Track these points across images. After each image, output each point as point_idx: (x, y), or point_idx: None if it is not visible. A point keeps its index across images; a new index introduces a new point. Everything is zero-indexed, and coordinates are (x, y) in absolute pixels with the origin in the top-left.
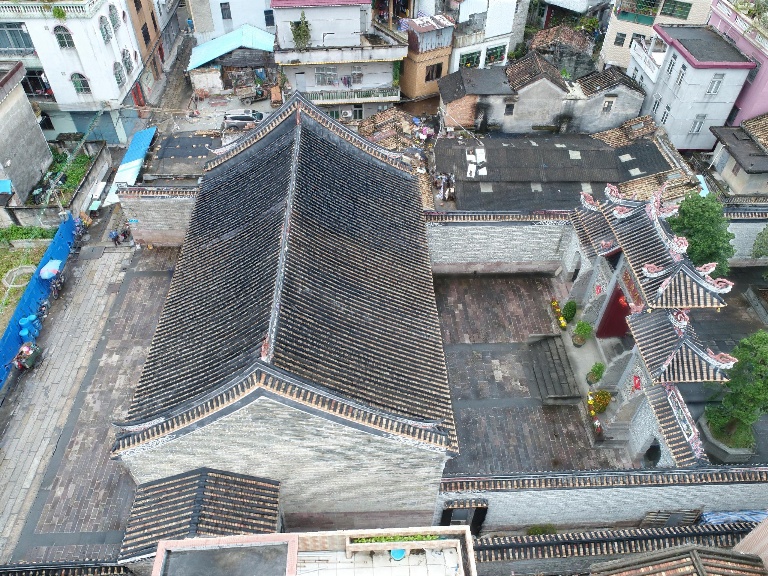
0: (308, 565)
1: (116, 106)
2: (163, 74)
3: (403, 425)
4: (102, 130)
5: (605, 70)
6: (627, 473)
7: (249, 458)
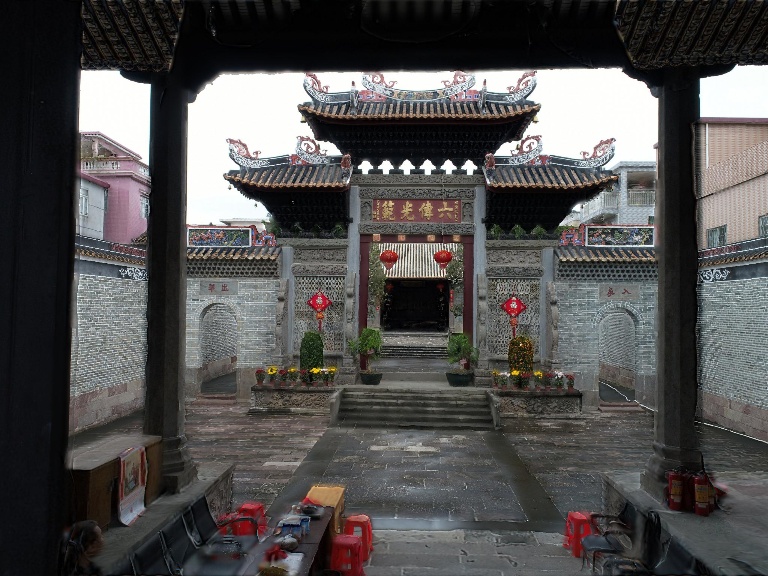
0: None
1: None
2: None
3: None
4: None
5: None
6: None
7: None
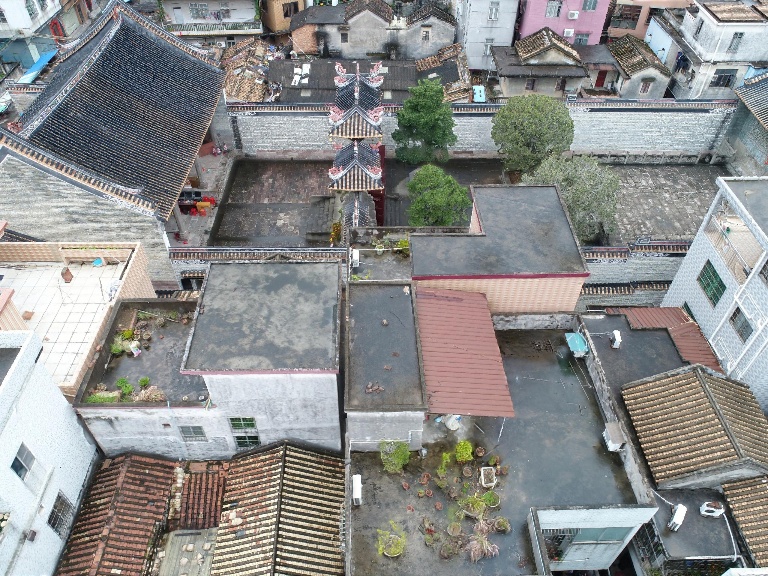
0: (39, 267)
1: (28, 34)
2: (89, 20)
3: (117, 190)
4: (21, 56)
5: (425, 6)
6: (303, 249)
7: (23, 217)
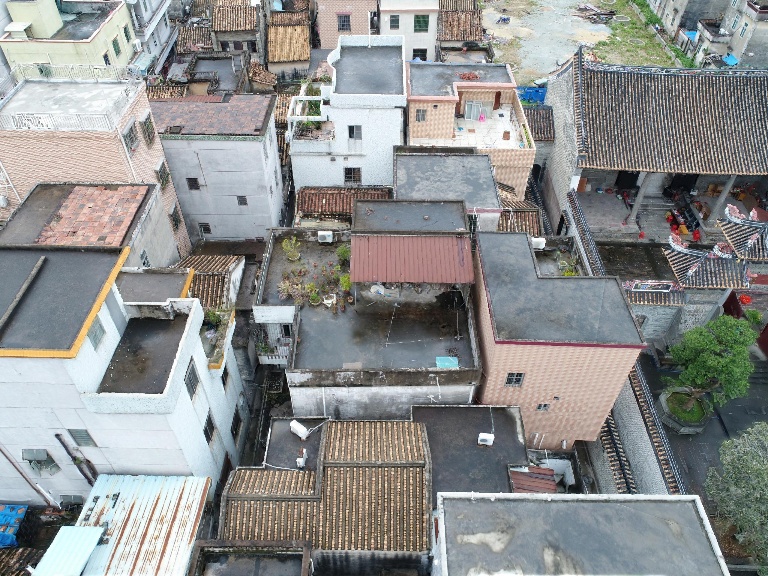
0: None
1: None
2: None
3: None
4: None
5: None
6: None
7: None
